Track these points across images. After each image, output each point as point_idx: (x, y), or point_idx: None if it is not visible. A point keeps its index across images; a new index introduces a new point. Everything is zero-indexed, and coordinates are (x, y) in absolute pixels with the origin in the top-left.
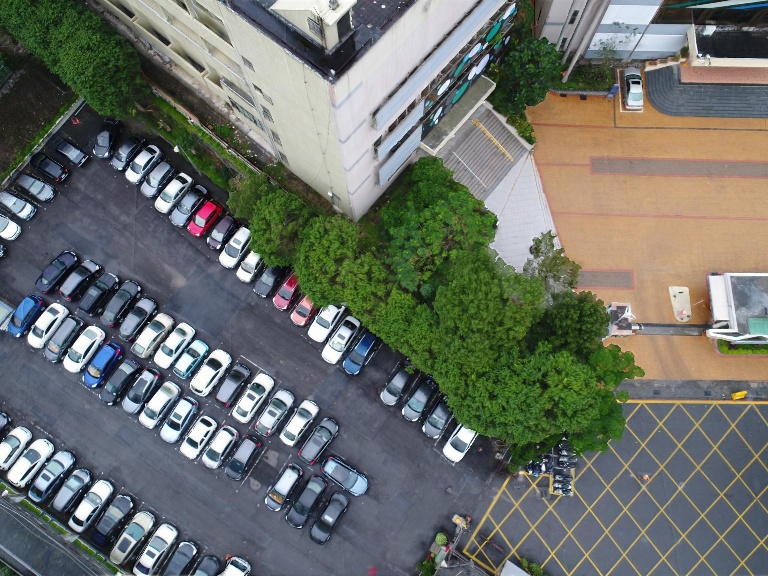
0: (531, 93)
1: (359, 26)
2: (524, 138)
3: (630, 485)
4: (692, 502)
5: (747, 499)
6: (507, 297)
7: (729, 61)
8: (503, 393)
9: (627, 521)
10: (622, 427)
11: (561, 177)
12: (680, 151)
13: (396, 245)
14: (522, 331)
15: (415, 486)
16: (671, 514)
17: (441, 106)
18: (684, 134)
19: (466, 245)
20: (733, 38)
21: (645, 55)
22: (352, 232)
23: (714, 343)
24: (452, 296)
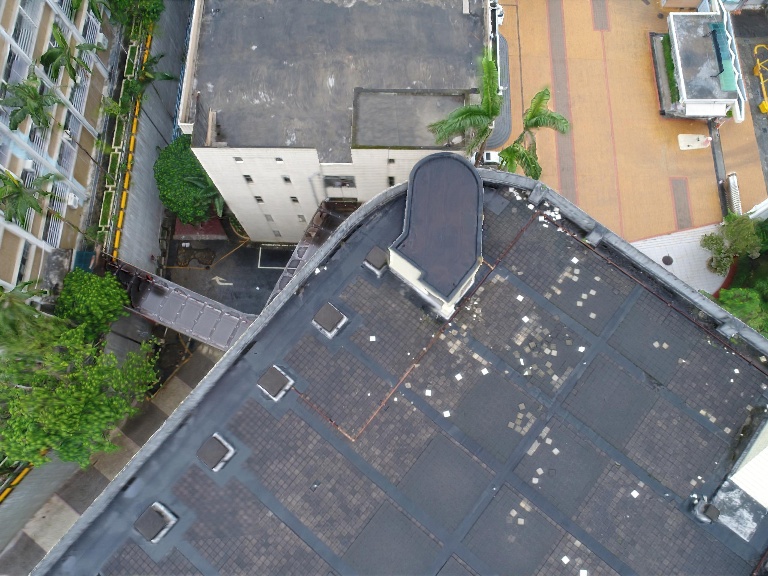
0: None
1: (766, 399)
2: None
3: None
4: None
5: None
6: None
7: None
8: None
9: None
10: None
11: None
12: None
13: None
14: None
15: None
16: None
17: None
18: None
19: (766, 314)
20: None
21: None
22: None
23: (724, 120)
24: None
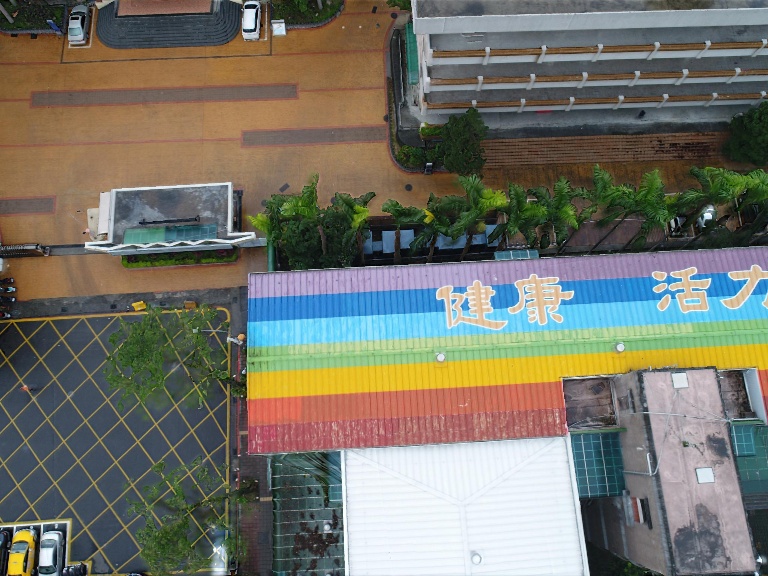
0: None
1: None
2: None
3: (21, 397)
4: (78, 409)
5: (131, 402)
6: None
7: None
8: None
9: (12, 431)
10: None
11: None
12: (120, 81)
13: None
14: None
15: None
16: (56, 422)
17: None
18: (126, 65)
19: None
20: None
21: None
22: None
23: None
24: None
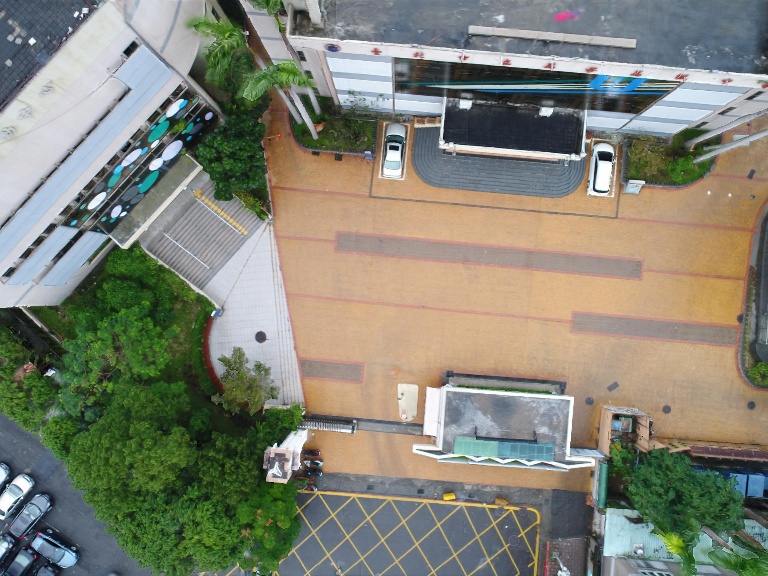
0: (229, 188)
1: None
2: (255, 212)
3: (329, 572)
4: None
5: None
6: (129, 463)
7: (479, 149)
8: (142, 539)
9: None
10: (283, 556)
11: (301, 253)
12: (438, 231)
13: (66, 360)
14: (158, 485)
15: (125, 560)
16: None
17: (116, 206)
18: (446, 210)
19: (127, 375)
20: (495, 114)
21: (411, 112)
22: (7, 354)
23: None
24: (80, 452)
